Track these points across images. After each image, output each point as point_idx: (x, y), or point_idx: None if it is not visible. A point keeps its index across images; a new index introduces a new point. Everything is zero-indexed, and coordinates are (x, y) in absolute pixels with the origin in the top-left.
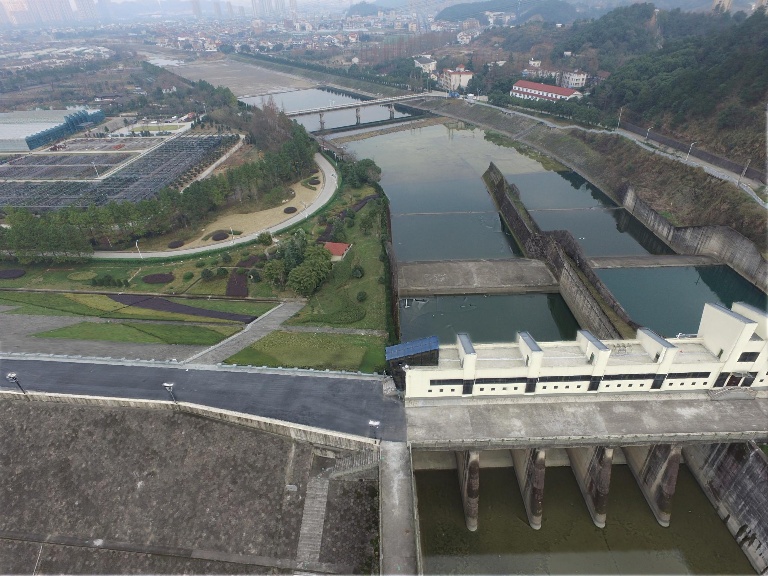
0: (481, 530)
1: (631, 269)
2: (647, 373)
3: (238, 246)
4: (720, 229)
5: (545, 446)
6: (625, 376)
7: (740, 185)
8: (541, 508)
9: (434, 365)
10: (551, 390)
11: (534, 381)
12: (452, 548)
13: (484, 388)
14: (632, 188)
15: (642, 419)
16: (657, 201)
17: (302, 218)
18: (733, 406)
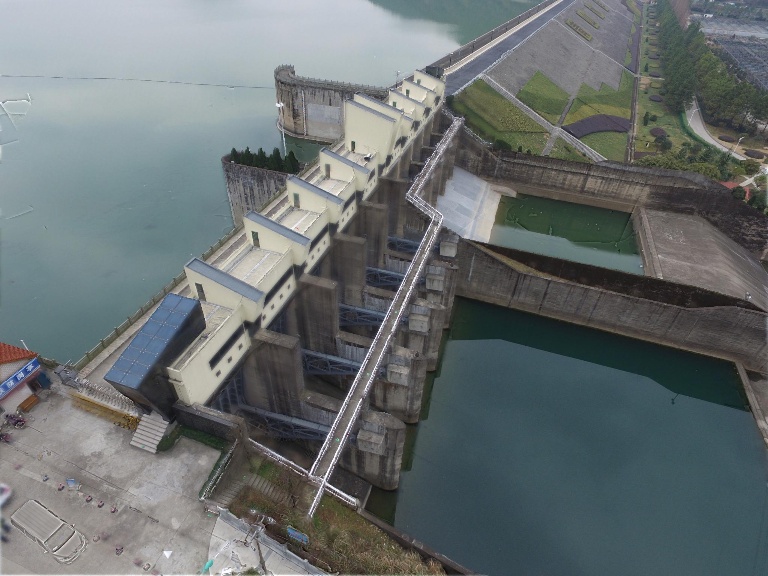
0: None
1: (764, 458)
2: None
3: None
4: None
5: None
6: None
7: None
8: None
9: None
10: None
11: None
12: None
13: None
14: None
15: None
16: None
17: None
18: None
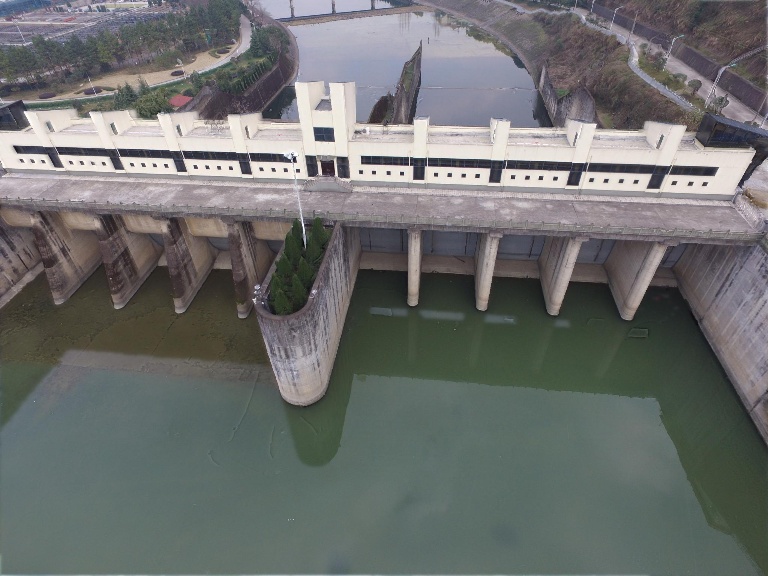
0: (66, 305)
1: None
2: (228, 151)
3: (100, 98)
4: (578, 91)
5: (89, 211)
6: (208, 155)
7: (629, 46)
8: (115, 286)
9: (16, 130)
10: (141, 168)
11: (116, 155)
12: (26, 314)
13: (73, 161)
14: (544, 64)
15: (211, 198)
16: (567, 78)
17: (180, 79)
18: (320, 196)
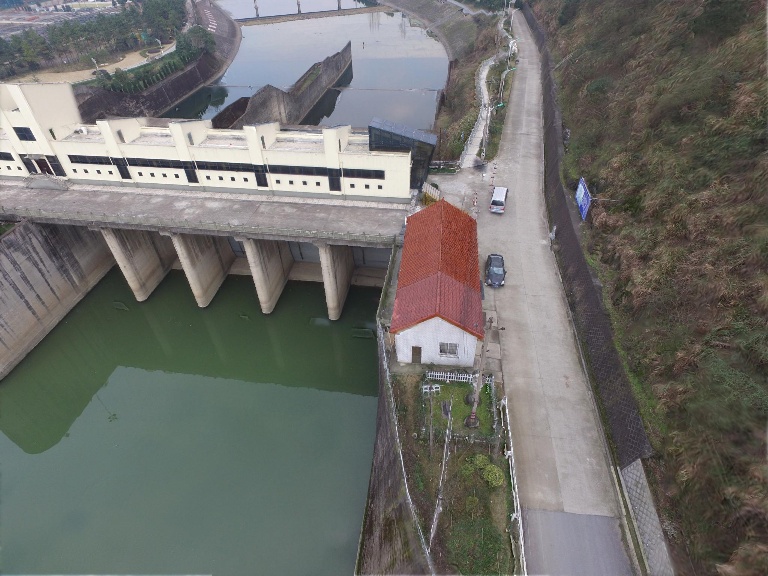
0: None
1: None
2: None
3: None
4: None
5: None
6: None
7: None
8: None
9: None
10: None
11: None
12: None
13: None
14: None
15: None
16: None
17: None
18: (36, 193)
